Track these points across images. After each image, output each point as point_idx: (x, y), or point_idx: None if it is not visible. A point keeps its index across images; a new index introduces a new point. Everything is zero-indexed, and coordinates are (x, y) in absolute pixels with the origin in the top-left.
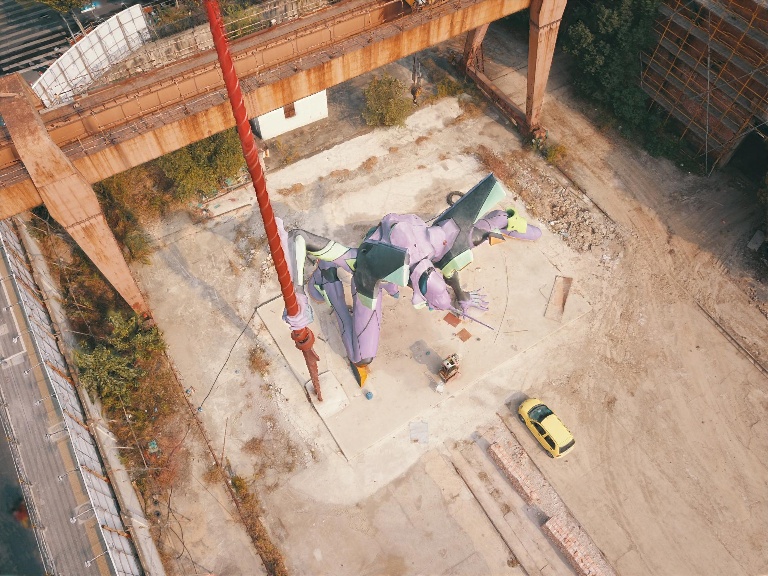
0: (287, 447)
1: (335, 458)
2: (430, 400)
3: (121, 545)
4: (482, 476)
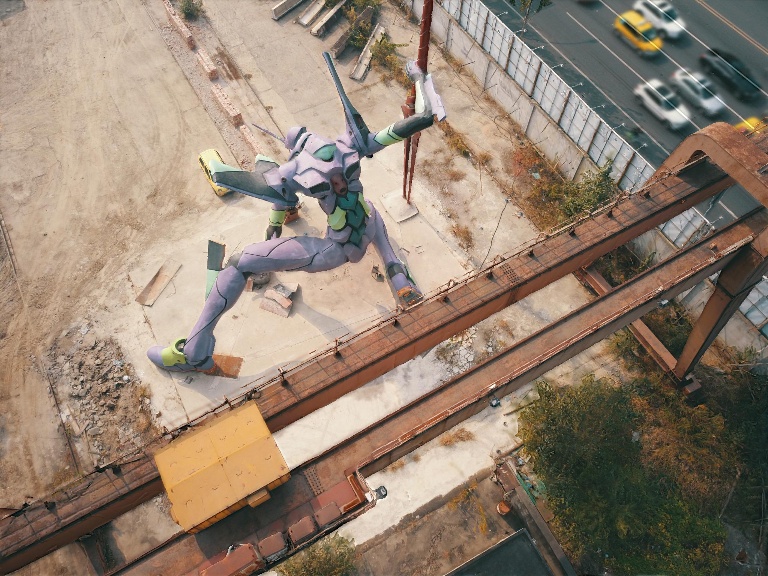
0: (430, 175)
1: (391, 167)
2: (310, 198)
3: (530, 79)
4: (278, 152)
